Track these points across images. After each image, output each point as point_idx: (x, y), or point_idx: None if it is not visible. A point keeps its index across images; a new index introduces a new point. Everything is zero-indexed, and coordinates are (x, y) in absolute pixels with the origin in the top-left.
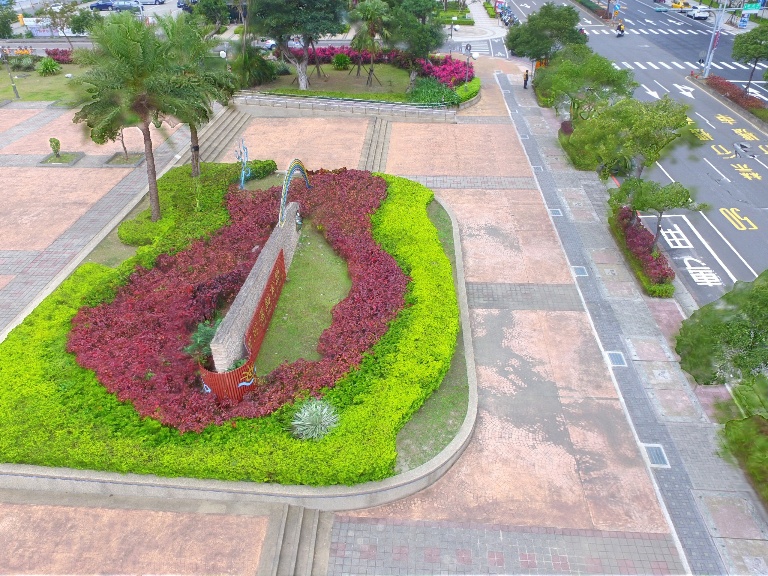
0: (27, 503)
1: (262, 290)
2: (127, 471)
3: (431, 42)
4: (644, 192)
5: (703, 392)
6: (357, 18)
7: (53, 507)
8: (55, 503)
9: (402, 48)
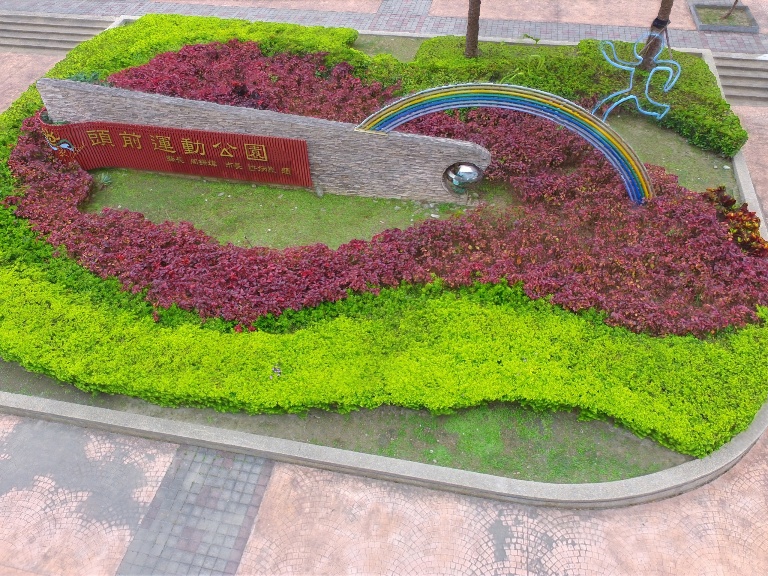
0: None
1: (192, 128)
2: None
3: None
4: None
5: None
6: None
7: None
8: None
9: None
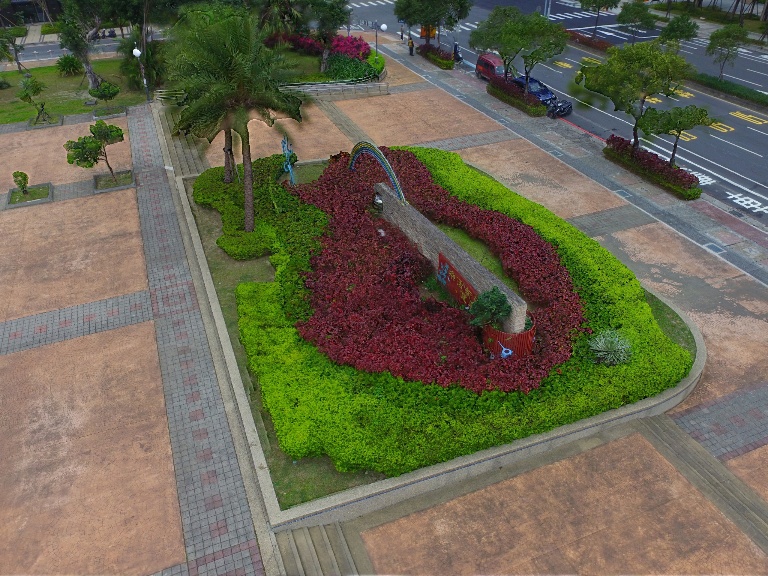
0: (437, 504)
1: None
2: (513, 439)
3: (344, 18)
4: (673, 117)
5: None
6: (263, 1)
7: (464, 497)
8: (462, 493)
9: (312, 27)
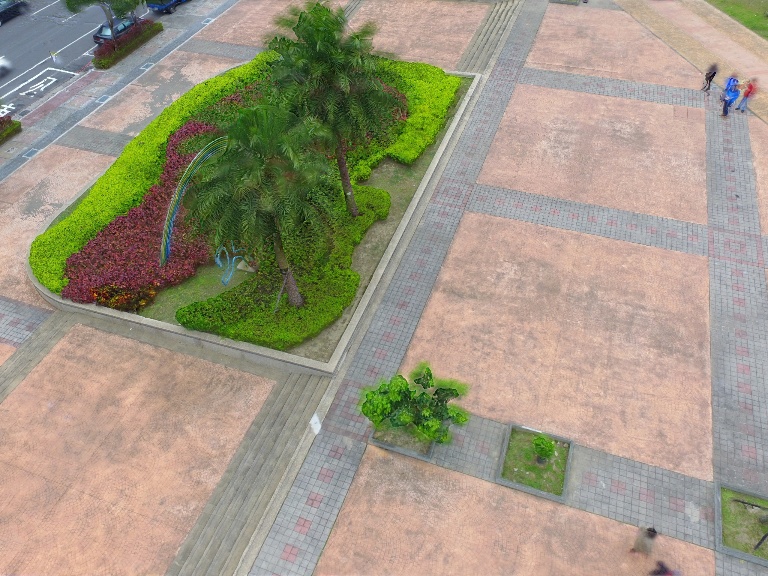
0: None
1: None
2: None
3: None
4: None
5: (89, 82)
6: None
7: None
8: None
9: None
